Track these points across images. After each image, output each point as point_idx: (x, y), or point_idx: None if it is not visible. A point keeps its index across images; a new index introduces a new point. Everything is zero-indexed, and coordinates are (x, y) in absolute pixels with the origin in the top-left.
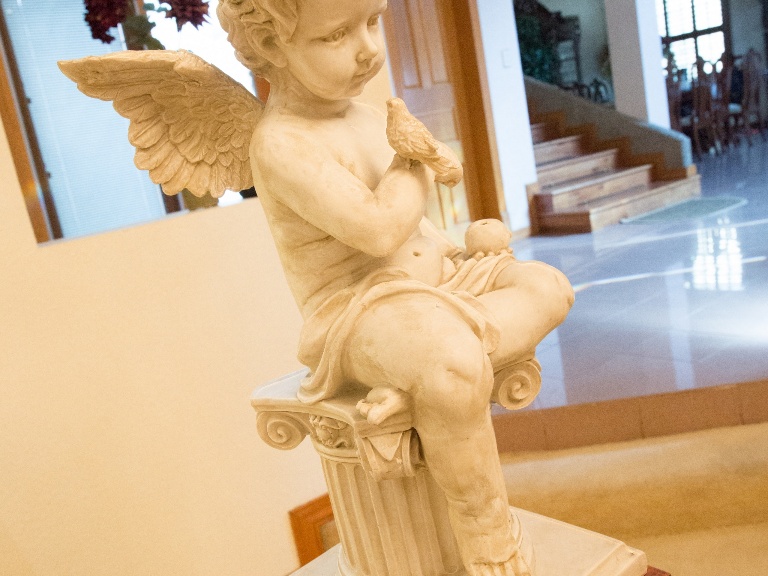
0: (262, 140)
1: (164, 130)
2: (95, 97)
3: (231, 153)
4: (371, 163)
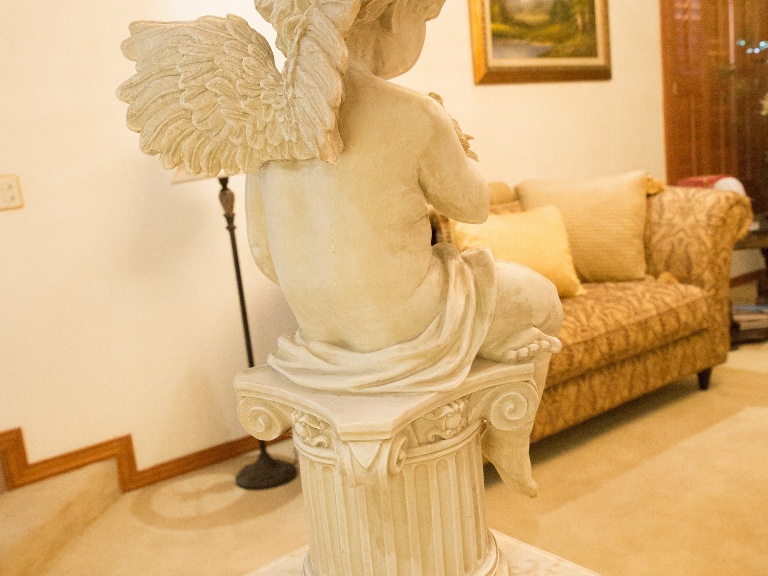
0: None
1: None
2: None
3: None
4: None
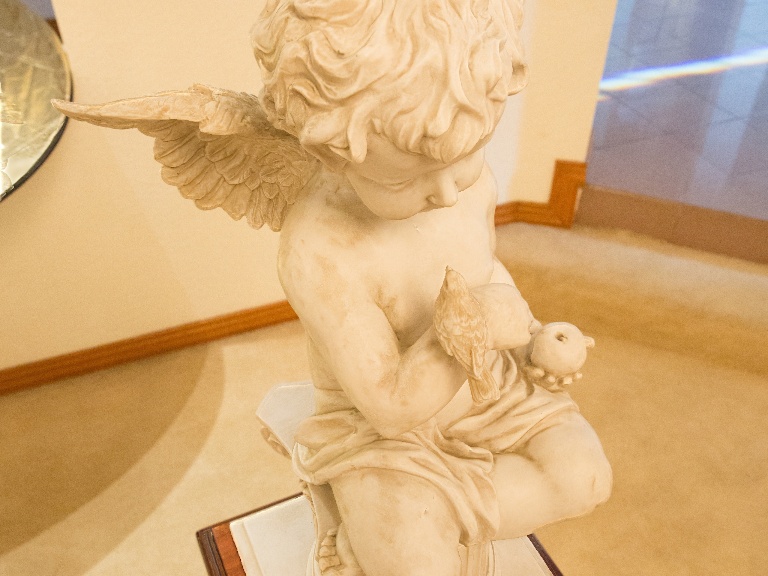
0: (287, 252)
1: (199, 146)
2: None
3: (277, 185)
4: (422, 292)
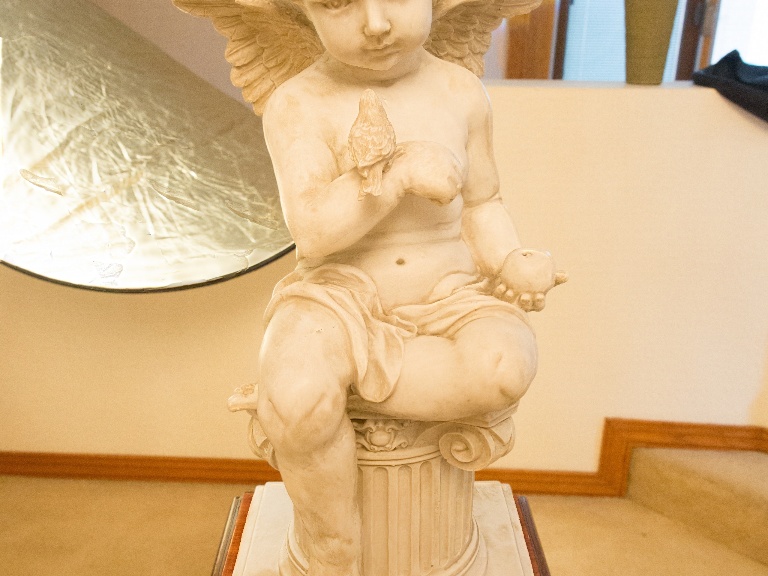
0: None
1: (259, 52)
2: None
3: None
4: None
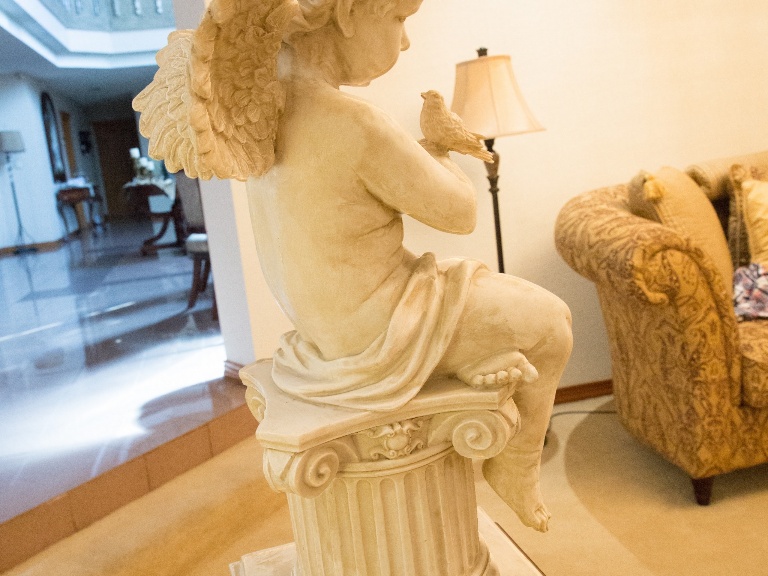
0: (367, 108)
1: None
2: (222, 8)
3: (243, 128)
4: None
